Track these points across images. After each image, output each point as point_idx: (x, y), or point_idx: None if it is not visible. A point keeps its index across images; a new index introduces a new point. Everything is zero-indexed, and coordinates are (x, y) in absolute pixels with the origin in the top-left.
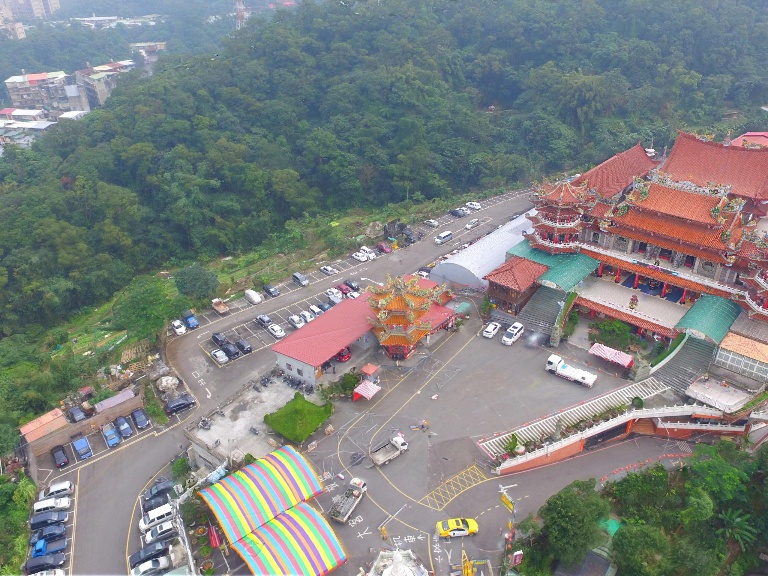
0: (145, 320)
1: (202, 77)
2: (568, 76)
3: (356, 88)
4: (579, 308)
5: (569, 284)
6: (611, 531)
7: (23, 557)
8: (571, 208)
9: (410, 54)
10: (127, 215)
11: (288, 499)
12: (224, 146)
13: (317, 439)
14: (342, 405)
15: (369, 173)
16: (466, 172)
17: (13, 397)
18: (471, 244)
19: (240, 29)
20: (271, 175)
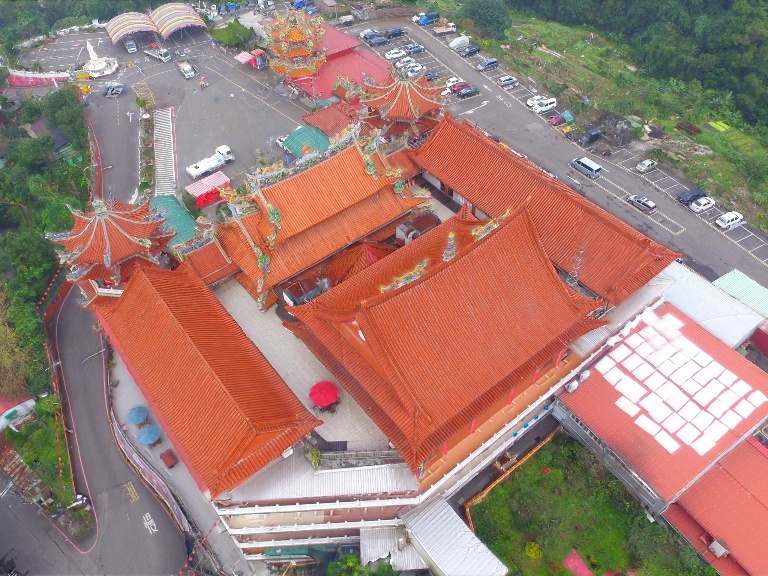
0: None
1: None
2: None
3: None
4: None
5: (295, 146)
6: None
7: None
8: None
9: None
10: None
11: (162, 26)
12: None
13: None
14: None
15: None
16: None
17: None
18: None
19: None
20: None
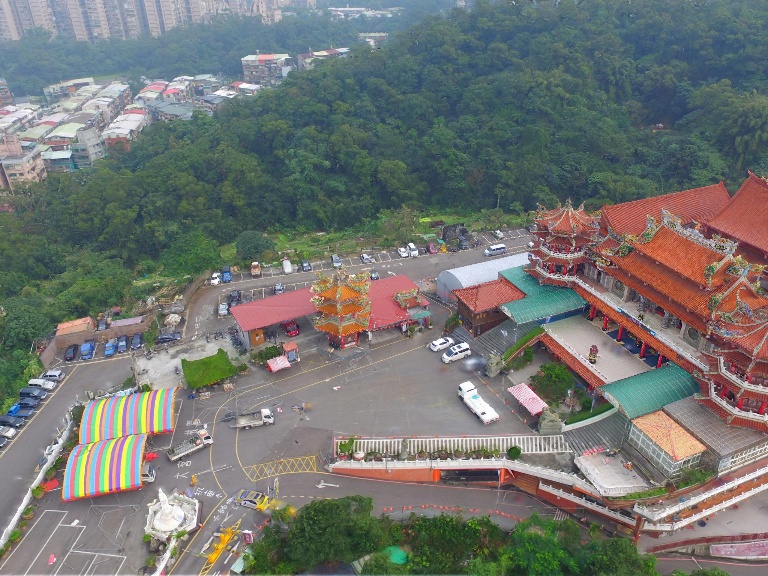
0: (178, 265)
1: (357, 67)
2: (741, 98)
3: (493, 90)
4: (546, 346)
5: (528, 316)
6: (391, 560)
7: (4, 413)
8: (568, 238)
9: (563, 59)
10: (246, 180)
11: (140, 426)
12: (347, 132)
13: (213, 391)
14: (258, 371)
15: (477, 176)
16: (584, 190)
17: (69, 301)
18: None
19: (417, 24)
20: (380, 164)
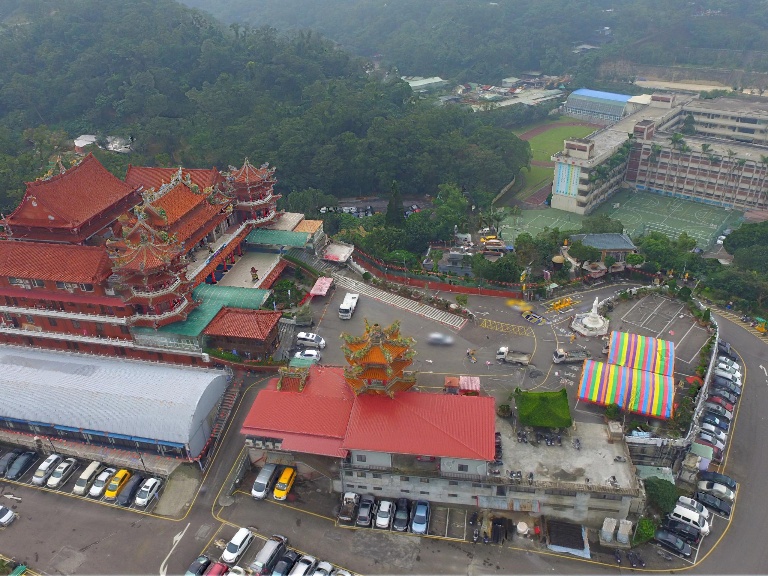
0: None
1: None
2: None
3: None
4: None
5: None
6: None
7: None
8: None
9: None
10: None
11: None
12: None
13: None
14: None
15: None
16: None
17: None
18: (19, 476)
19: None
20: None
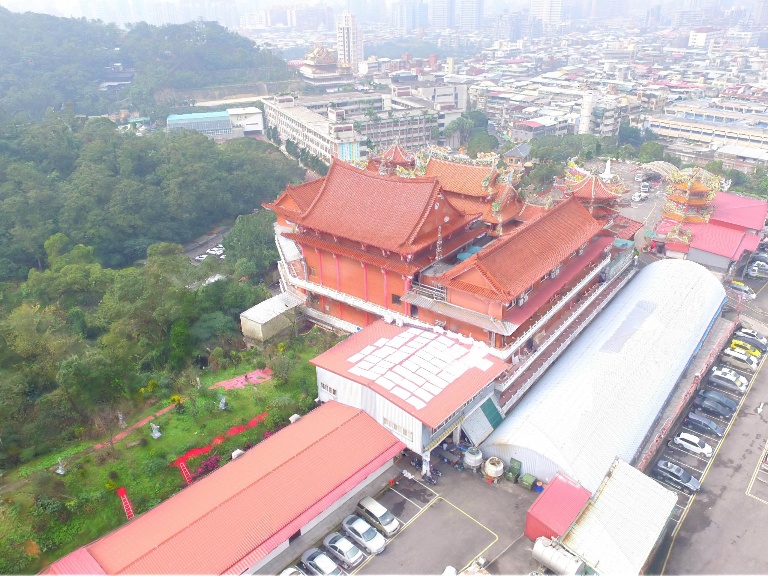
0: None
1: None
2: None
3: None
4: None
5: None
6: None
7: None
8: None
9: None
10: None
11: None
12: None
13: None
14: None
15: None
16: None
17: None
18: None
19: None
20: None
